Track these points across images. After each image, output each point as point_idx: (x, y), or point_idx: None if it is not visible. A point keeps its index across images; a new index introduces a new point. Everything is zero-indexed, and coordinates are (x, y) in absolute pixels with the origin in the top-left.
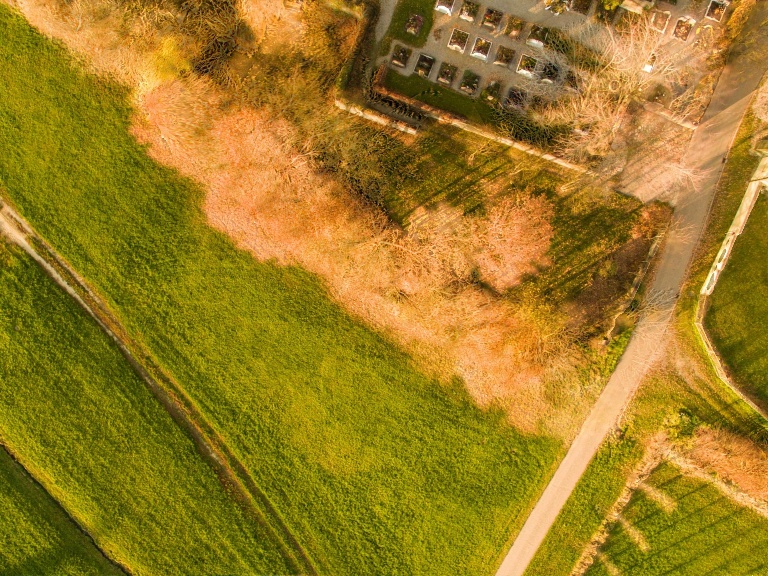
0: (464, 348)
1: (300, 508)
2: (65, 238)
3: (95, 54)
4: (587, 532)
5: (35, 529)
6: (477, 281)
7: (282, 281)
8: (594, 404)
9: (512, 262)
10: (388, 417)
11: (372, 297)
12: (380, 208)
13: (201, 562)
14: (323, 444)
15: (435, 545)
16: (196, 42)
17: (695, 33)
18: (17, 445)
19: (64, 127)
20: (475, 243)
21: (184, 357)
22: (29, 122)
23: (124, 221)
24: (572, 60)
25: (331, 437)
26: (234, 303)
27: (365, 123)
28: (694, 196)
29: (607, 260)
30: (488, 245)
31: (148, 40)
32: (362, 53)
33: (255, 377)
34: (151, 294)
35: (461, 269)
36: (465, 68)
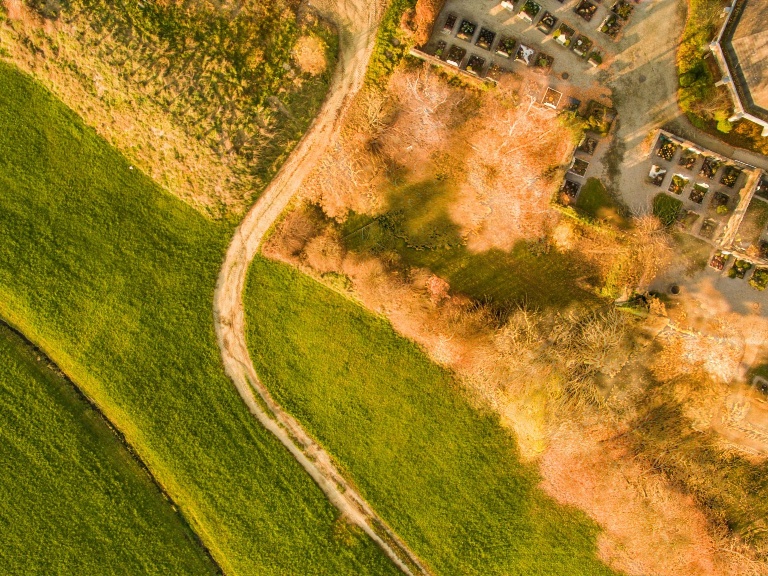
0: None
1: None
2: (404, 521)
3: (455, 360)
4: None
5: None
6: None
7: (610, 568)
8: None
9: None
10: None
11: None
12: (722, 519)
13: None
14: None
15: None
16: (565, 363)
17: None
18: None
19: (415, 422)
20: None
21: None
22: (381, 415)
23: (463, 508)
24: None
25: None
26: None
27: (715, 442)
28: None
29: None
30: None
31: (517, 358)
32: None
33: None
34: (482, 574)
35: None
36: None
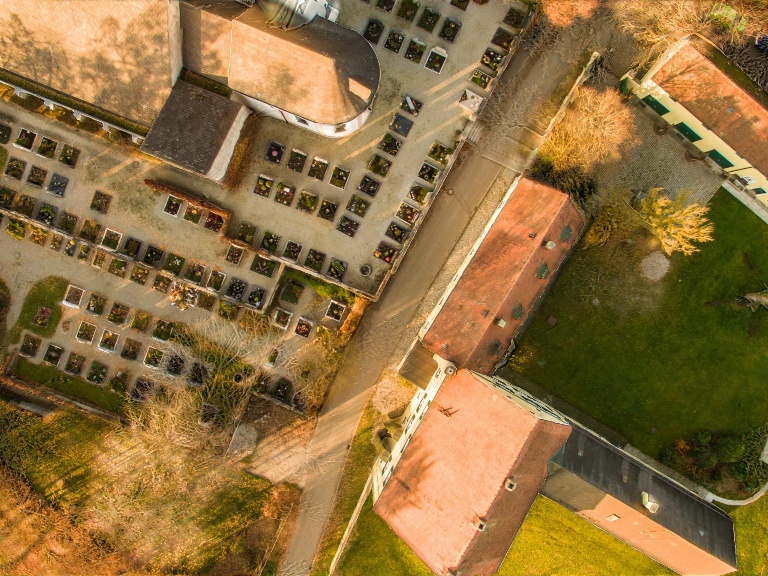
0: None
1: None
2: None
3: None
4: None
5: None
6: (117, 550)
7: None
8: None
9: (150, 534)
10: None
11: (27, 554)
12: (22, 480)
13: None
14: None
15: None
16: None
17: (316, 331)
18: None
19: None
20: (113, 515)
21: None
22: None
23: None
24: (198, 353)
25: None
26: None
27: None
28: (321, 479)
29: (240, 535)
30: (127, 517)
31: None
32: None
33: None
34: None
35: (102, 538)
36: (93, 358)
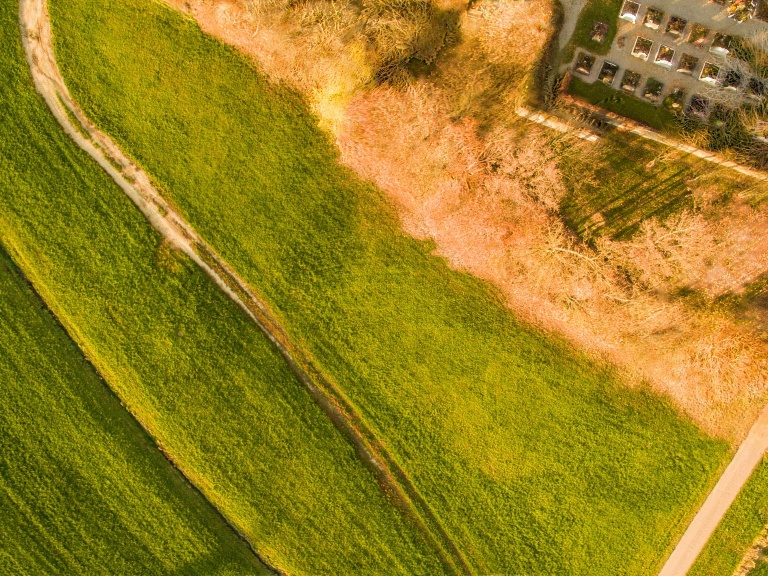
0: (632, 354)
1: (459, 513)
2: (230, 244)
3: (268, 61)
4: (749, 536)
5: (193, 535)
6: (651, 287)
7: (449, 287)
8: (762, 409)
9: (687, 268)
10: (552, 422)
11: (541, 303)
12: (556, 214)
13: (359, 567)
14: (485, 449)
15: (595, 550)
16: (375, 49)
17: None
18: (176, 451)
19: (233, 133)
20: (651, 249)
21: (347, 363)
22: (197, 128)
23: (290, 227)
24: (754, 68)
25: (493, 442)
26: (399, 309)
27: (543, 130)
28: None
29: None
30: (664, 251)
31: (326, 47)
32: (545, 60)
33: (418, 383)
34: (315, 300)
35: (636, 275)
36: (648, 75)
